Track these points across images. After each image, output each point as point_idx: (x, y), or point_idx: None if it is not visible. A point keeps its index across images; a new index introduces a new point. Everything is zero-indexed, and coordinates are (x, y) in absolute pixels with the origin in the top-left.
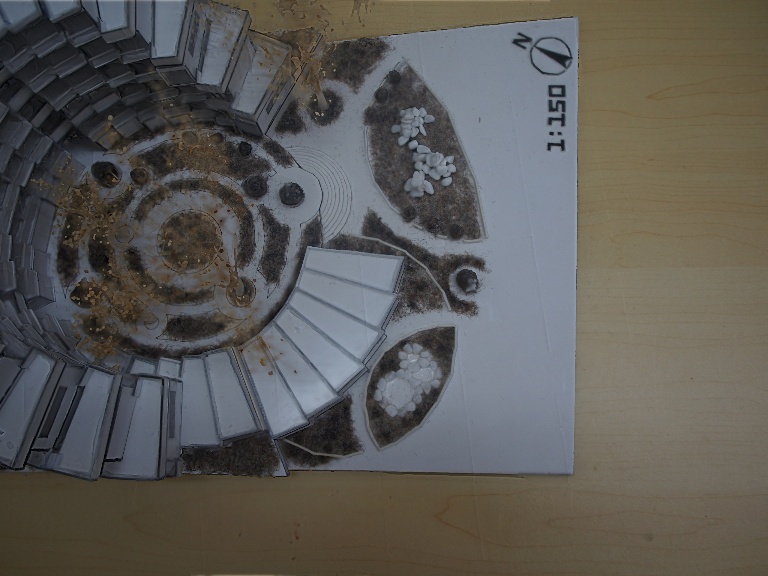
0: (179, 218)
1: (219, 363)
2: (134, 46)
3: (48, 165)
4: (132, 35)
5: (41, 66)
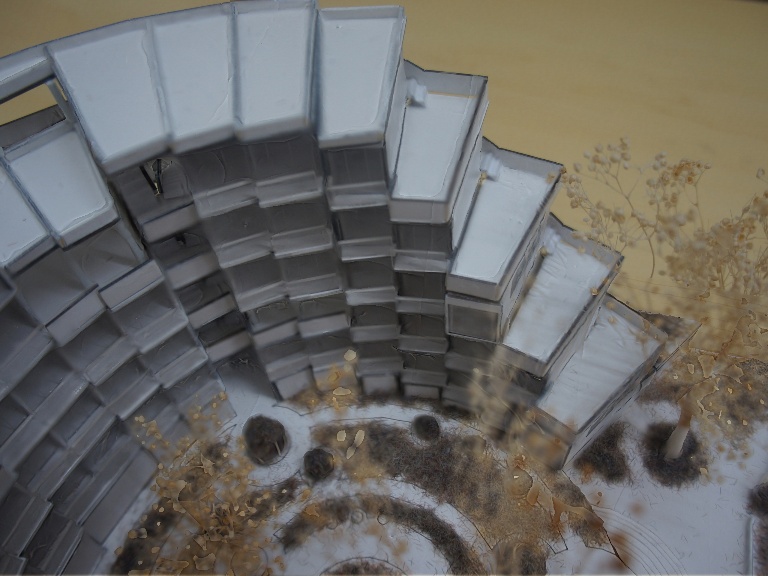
0: (358, 570)
1: None
2: (428, 244)
3: (181, 394)
4: (443, 220)
5: (254, 226)
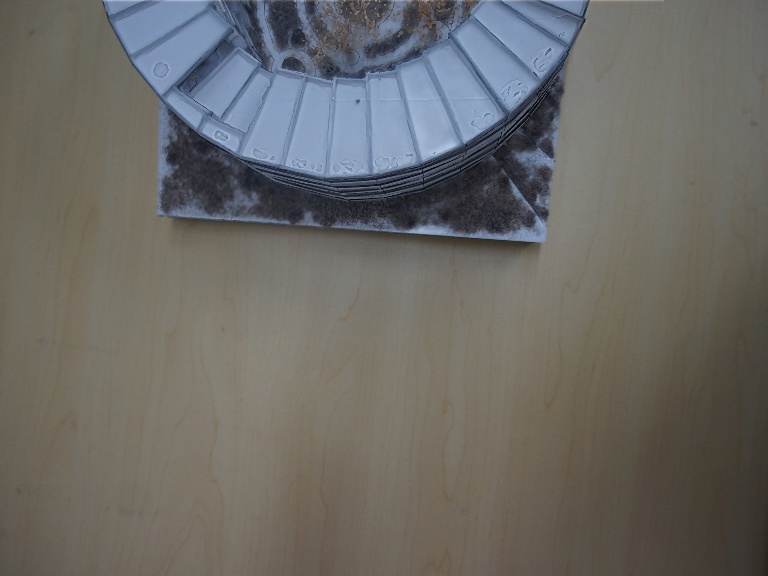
0: (342, 8)
1: None
2: None
3: None
4: None
5: None
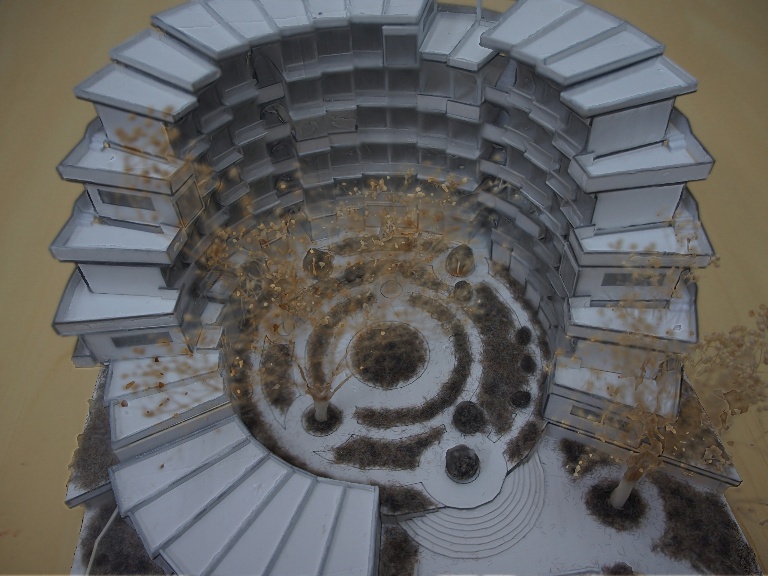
0: (417, 339)
1: (211, 390)
2: (582, 207)
3: None
4: (585, 189)
5: (529, 131)
